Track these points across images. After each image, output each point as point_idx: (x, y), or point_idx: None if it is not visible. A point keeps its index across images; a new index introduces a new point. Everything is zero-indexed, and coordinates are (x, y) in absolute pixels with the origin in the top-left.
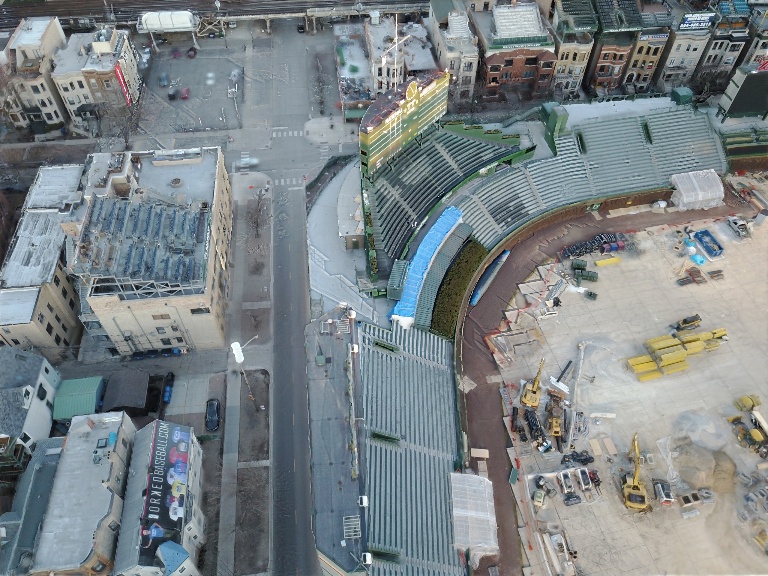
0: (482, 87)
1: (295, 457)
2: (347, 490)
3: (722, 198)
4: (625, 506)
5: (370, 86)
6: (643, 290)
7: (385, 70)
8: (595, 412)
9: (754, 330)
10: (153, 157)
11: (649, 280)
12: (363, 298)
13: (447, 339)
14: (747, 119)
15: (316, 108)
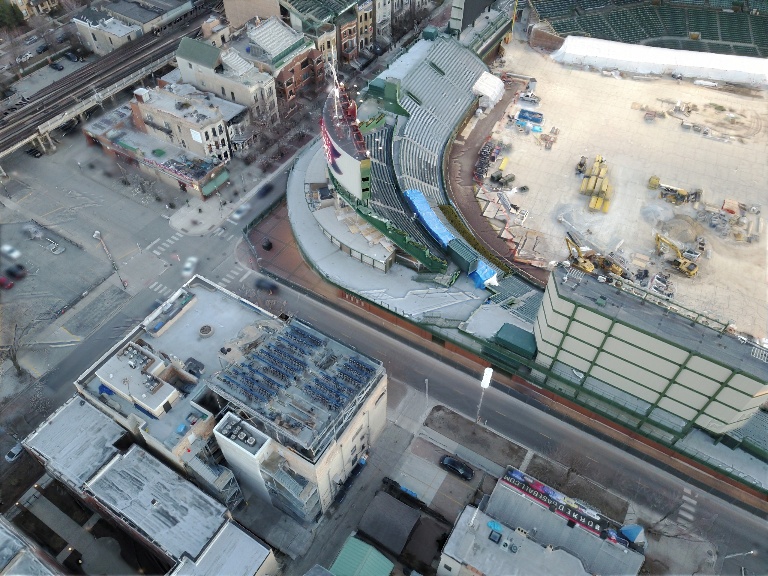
0: (283, 105)
1: (538, 431)
2: (728, 344)
3: (504, 86)
4: (688, 278)
5: (195, 157)
6: (539, 166)
7: (210, 132)
8: (614, 247)
9: (606, 146)
10: (150, 329)
11: (534, 158)
12: (446, 292)
13: (511, 275)
14: (466, 31)
15: (160, 207)
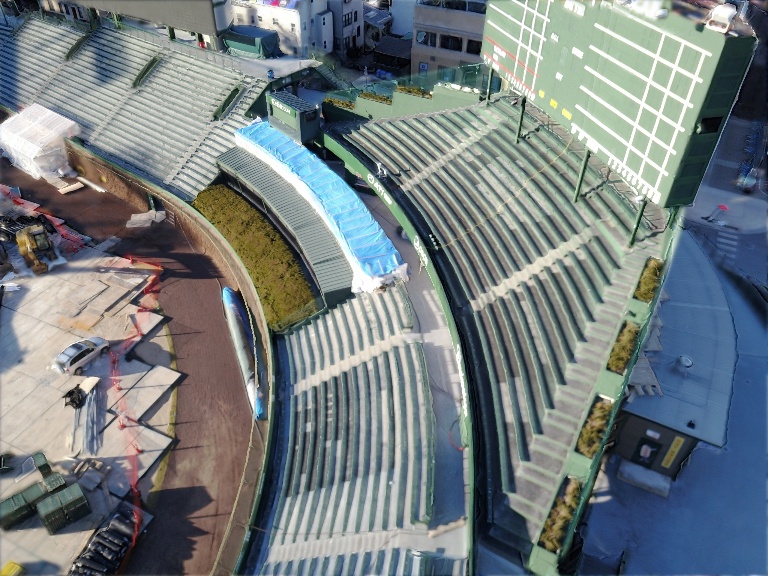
0: None
1: None
2: None
3: None
4: None
5: None
6: None
7: None
8: None
9: None
10: None
11: None
12: None
13: None
14: None
15: None
